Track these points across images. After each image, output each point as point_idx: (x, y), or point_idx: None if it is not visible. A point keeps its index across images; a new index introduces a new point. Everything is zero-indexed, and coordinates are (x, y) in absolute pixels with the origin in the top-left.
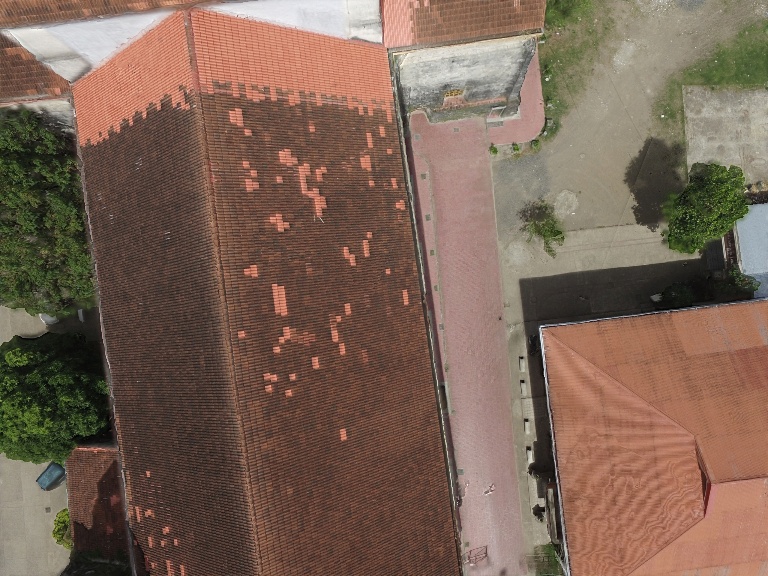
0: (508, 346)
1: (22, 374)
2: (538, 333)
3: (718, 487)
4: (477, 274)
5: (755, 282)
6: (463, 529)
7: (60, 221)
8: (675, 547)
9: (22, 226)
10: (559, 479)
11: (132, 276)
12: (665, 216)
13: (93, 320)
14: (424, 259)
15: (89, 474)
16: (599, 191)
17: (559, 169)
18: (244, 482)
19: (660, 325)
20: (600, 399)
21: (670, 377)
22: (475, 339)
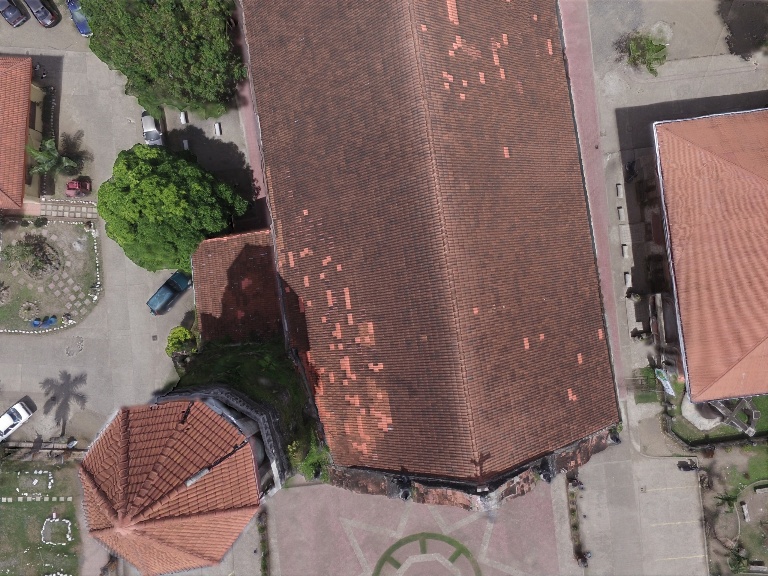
0: (605, 174)
1: (153, 165)
2: (635, 159)
3: None
4: None
5: None
6: None
7: (196, 4)
8: None
9: (160, 7)
10: (674, 271)
11: (292, 15)
12: (758, 46)
13: (197, 152)
14: None
15: (218, 263)
16: (693, 22)
17: (653, 1)
18: (429, 167)
19: None
20: (718, 186)
21: None
22: None
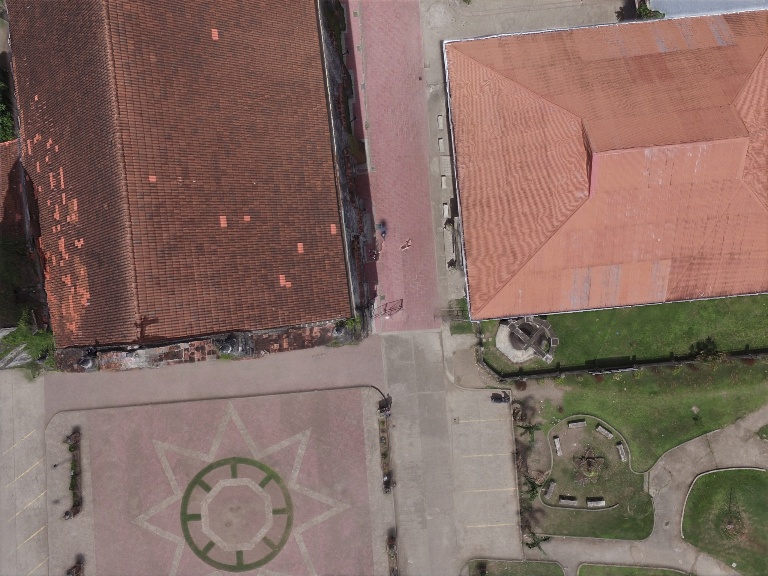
0: (427, 105)
1: None
2: None
3: (599, 158)
4: (399, 35)
5: (660, 14)
6: (380, 283)
7: None
8: (564, 236)
9: None
10: (459, 189)
11: None
12: None
13: None
14: (347, 20)
15: (1, 168)
16: None
17: None
18: (105, 33)
19: (560, 39)
20: (497, 102)
21: (564, 77)
22: (395, 98)
